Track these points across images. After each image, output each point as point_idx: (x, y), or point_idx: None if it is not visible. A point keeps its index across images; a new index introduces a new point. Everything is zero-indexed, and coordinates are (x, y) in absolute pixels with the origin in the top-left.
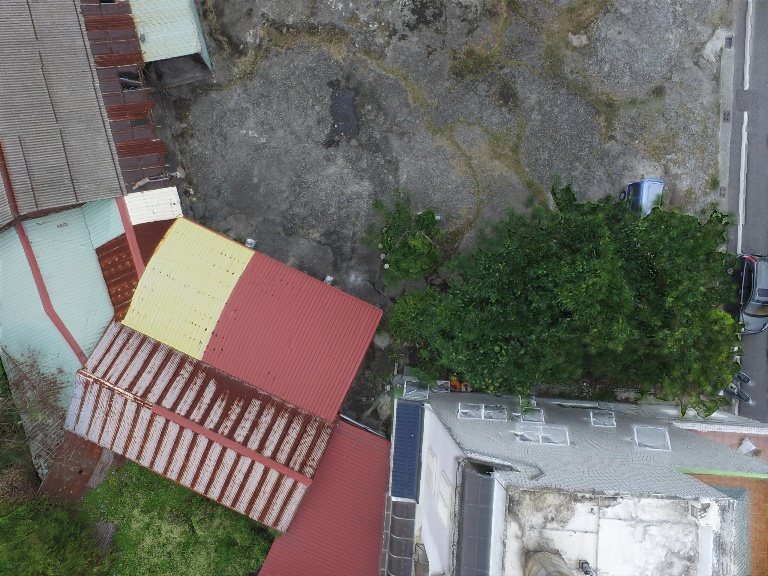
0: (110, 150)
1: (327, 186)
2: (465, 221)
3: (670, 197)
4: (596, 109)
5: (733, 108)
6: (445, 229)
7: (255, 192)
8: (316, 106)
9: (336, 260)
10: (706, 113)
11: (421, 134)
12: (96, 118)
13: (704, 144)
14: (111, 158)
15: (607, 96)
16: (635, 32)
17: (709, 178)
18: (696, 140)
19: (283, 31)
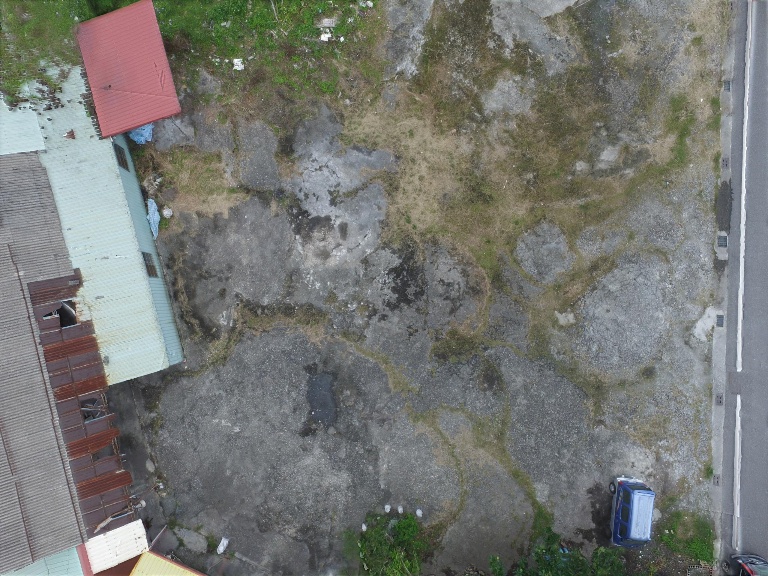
0: (70, 494)
1: (304, 478)
2: (448, 513)
3: (662, 486)
4: (584, 392)
5: (726, 390)
6: (427, 522)
7: (228, 485)
8: (292, 392)
9: (313, 557)
10: (698, 396)
11: (402, 421)
12: (55, 460)
13: (696, 429)
14: (71, 502)
15: (595, 378)
16: (624, 310)
17: (702, 465)
18: (688, 425)
19: (258, 312)
